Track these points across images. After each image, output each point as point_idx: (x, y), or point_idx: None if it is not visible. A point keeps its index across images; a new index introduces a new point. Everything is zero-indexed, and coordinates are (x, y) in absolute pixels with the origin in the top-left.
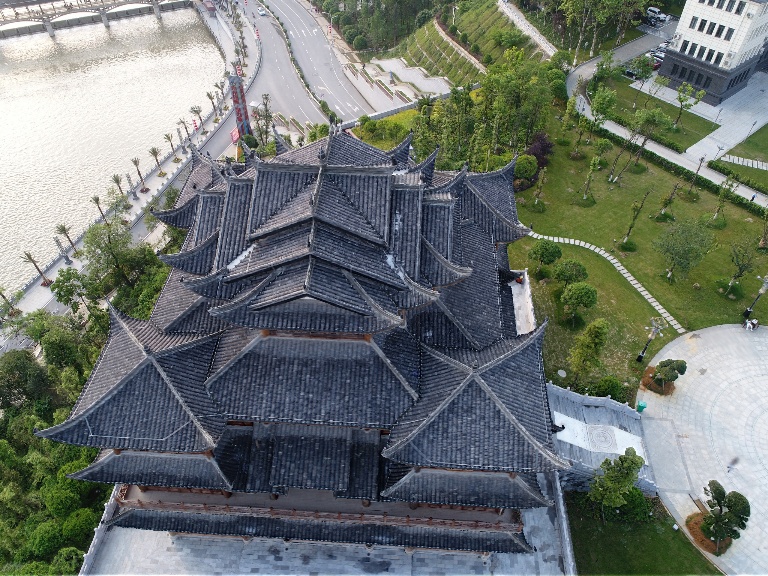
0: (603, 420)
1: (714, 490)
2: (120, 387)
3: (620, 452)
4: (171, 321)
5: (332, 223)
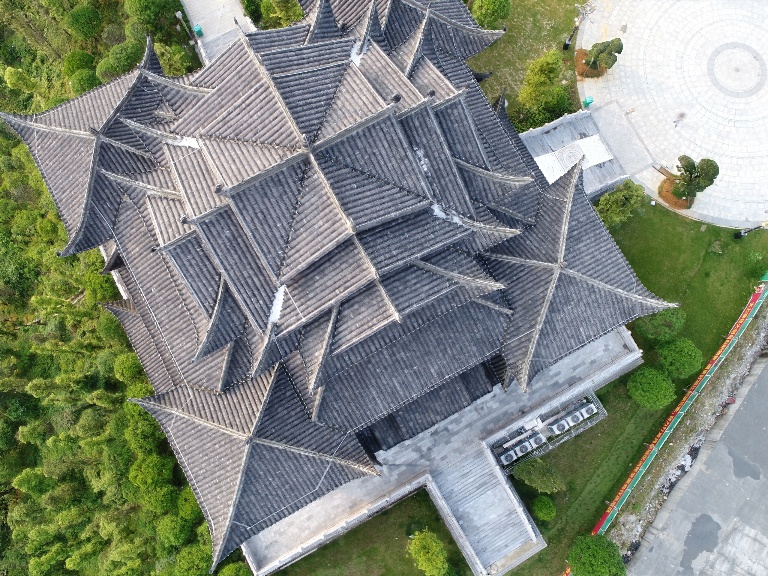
0: (566, 139)
1: (686, 166)
2: (242, 480)
3: (592, 163)
4: (221, 380)
5: (375, 224)
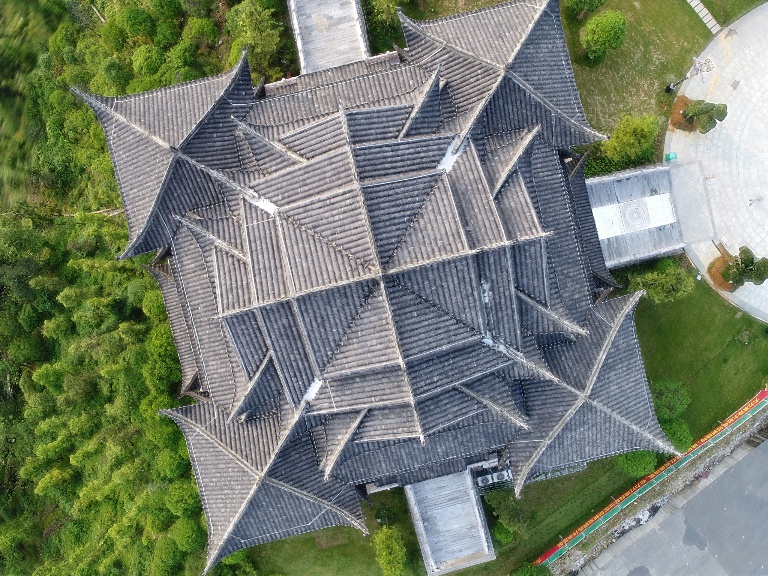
0: (635, 193)
1: (745, 259)
2: (246, 506)
3: (653, 225)
4: (246, 413)
5: (425, 356)
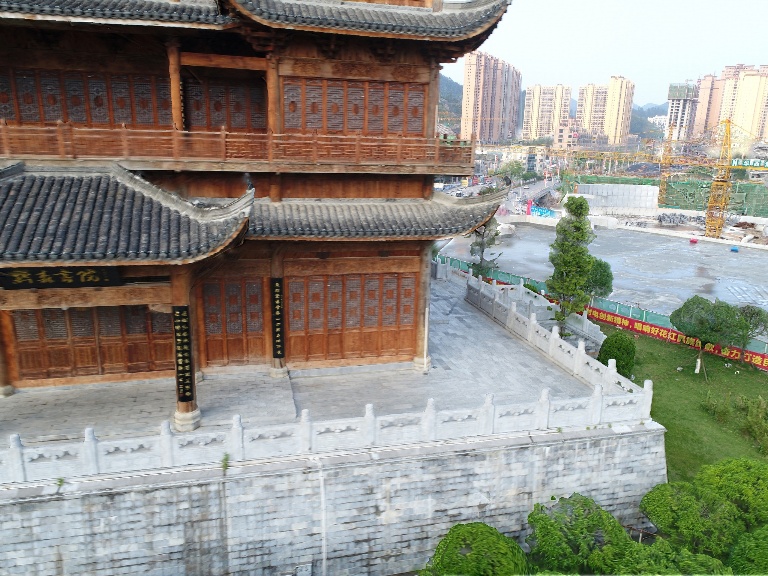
0: None
1: None
2: None
3: None
4: None
5: None
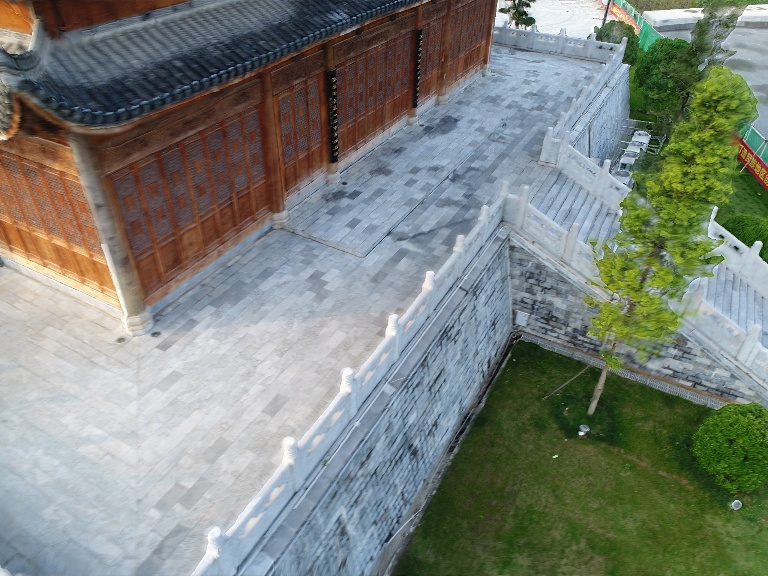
0: None
1: None
2: None
3: None
4: None
5: None
